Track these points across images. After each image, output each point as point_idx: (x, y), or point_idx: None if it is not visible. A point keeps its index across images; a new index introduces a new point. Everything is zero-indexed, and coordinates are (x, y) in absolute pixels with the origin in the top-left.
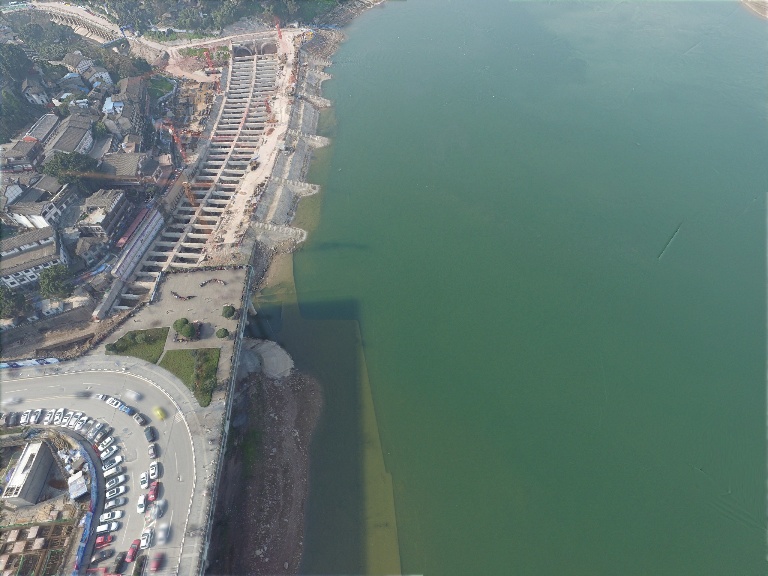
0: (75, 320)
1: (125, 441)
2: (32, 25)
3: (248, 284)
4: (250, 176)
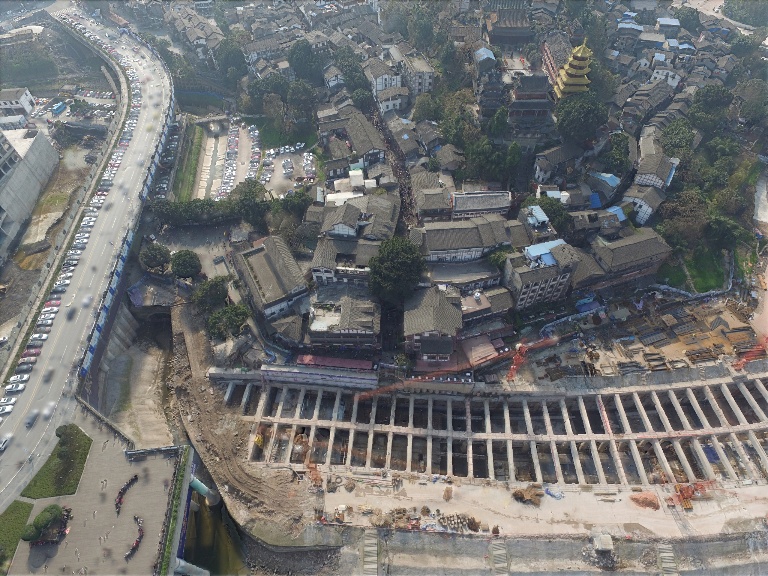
0: None
1: None
2: (725, 91)
3: None
4: (497, 495)
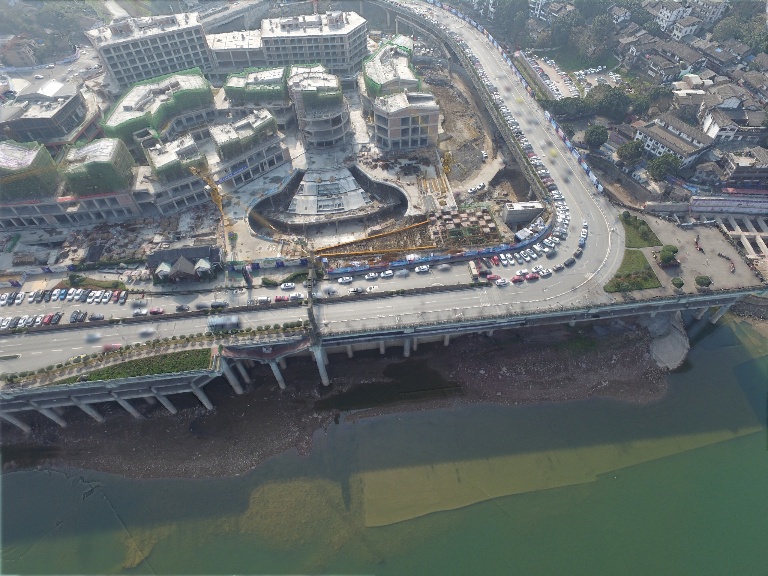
0: (636, 195)
1: (559, 249)
2: None
3: (745, 292)
4: None
